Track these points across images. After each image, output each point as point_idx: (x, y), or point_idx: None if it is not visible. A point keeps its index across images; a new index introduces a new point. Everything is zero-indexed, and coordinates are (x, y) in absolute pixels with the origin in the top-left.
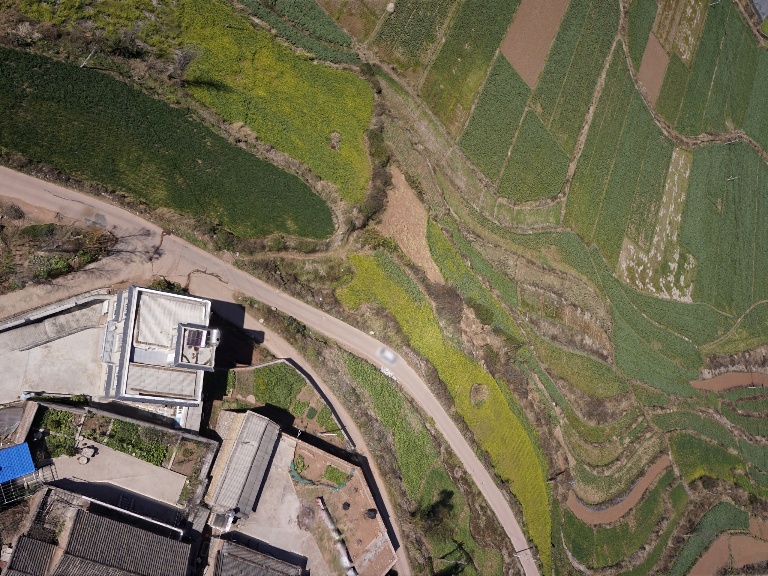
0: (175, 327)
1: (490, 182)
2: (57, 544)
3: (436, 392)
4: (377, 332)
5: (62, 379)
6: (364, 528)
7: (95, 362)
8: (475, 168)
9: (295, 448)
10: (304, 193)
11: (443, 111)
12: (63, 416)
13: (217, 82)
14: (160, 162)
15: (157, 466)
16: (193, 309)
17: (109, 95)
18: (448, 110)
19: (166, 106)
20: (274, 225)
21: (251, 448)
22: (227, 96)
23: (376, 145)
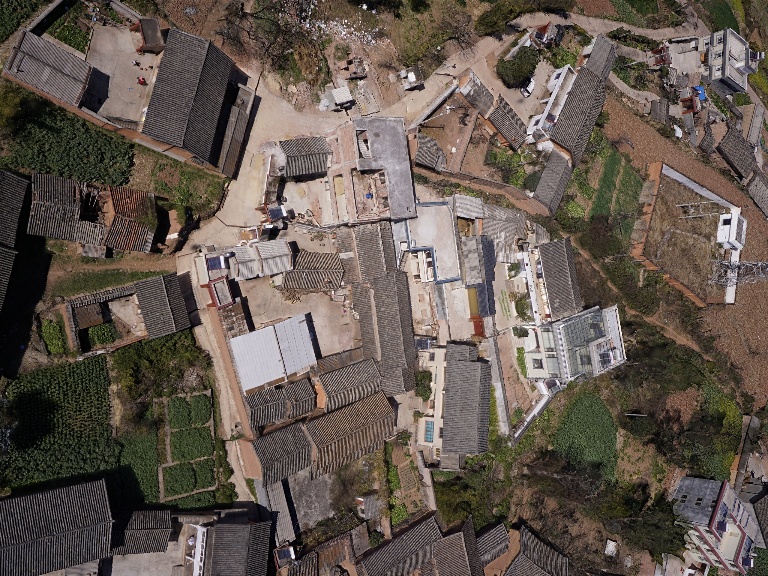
0: None
1: None
2: (713, 133)
3: None
4: (761, 98)
5: (688, 71)
6: None
7: (696, 67)
8: None
9: (761, 132)
10: (731, 14)
11: None
12: None
13: None
14: None
15: None
16: (741, 46)
17: None
18: None
19: None
20: (723, 27)
21: (760, 119)
22: None
23: None
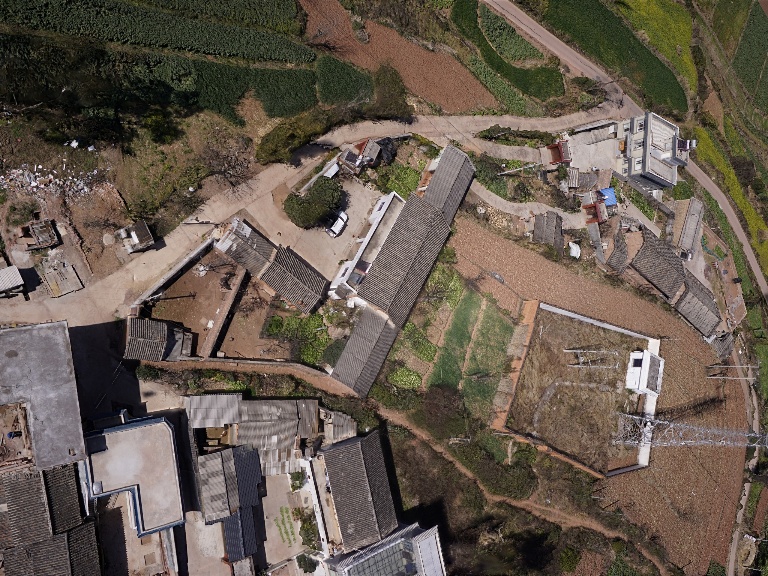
0: (665, 139)
1: (750, 96)
2: (627, 244)
3: (743, 227)
4: (714, 179)
5: (602, 165)
6: (732, 289)
7: (614, 159)
8: (742, 84)
9: (703, 229)
10: (674, 81)
11: (723, 40)
12: (616, 181)
13: (625, 3)
14: (615, 50)
15: (650, 220)
16: (670, 131)
17: (590, 5)
18: (725, 39)
19: (614, 15)
20: (663, 99)
21: (696, 218)
22: (632, 13)
23: (699, 57)
